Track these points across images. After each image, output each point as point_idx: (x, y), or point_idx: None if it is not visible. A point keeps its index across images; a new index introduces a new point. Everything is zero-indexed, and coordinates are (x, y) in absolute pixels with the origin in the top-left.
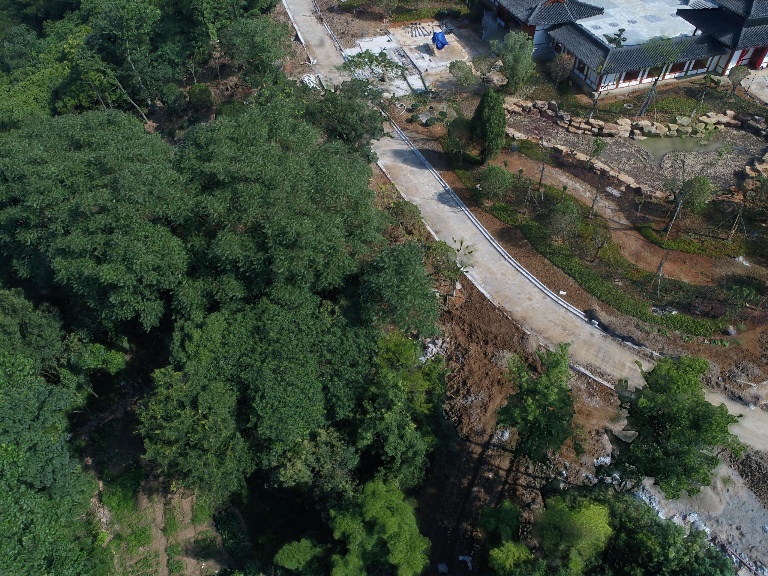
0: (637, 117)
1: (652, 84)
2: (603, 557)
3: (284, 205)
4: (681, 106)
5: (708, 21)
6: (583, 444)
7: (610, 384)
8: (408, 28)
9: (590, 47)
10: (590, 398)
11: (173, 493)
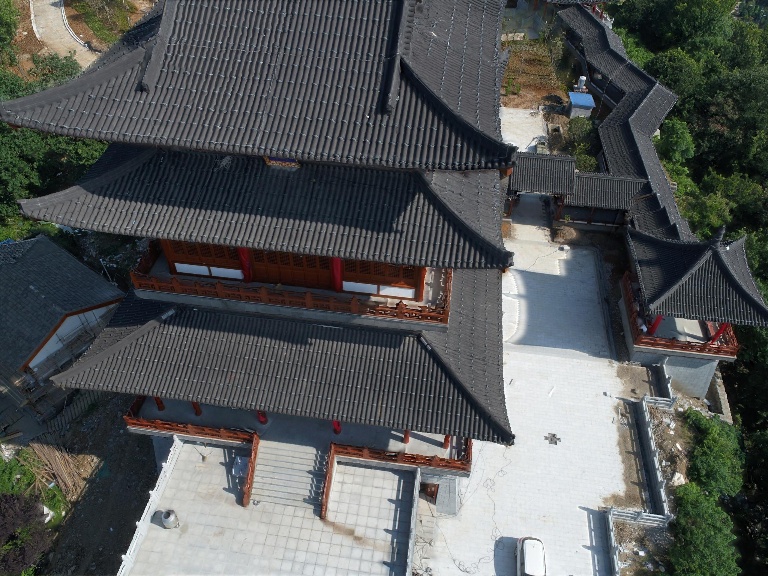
0: None
1: None
2: None
3: None
4: None
5: None
6: (4, 60)
7: None
8: None
9: None
10: None
11: None
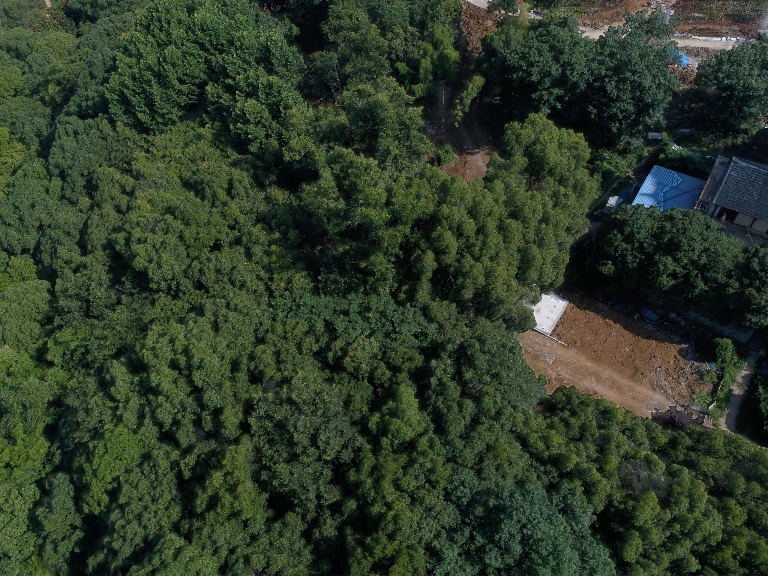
0: None
1: None
2: None
3: None
4: None
5: None
6: None
7: None
8: None
9: None
10: None
11: None
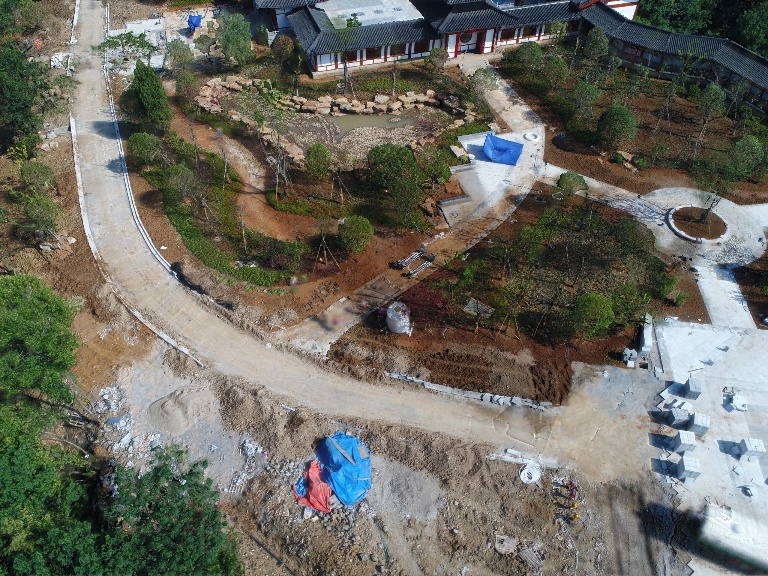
0: (340, 95)
1: (373, 66)
2: None
3: None
4: (388, 86)
5: (430, 7)
6: None
7: (153, 325)
8: (183, 12)
9: (310, 29)
10: (129, 337)
11: None
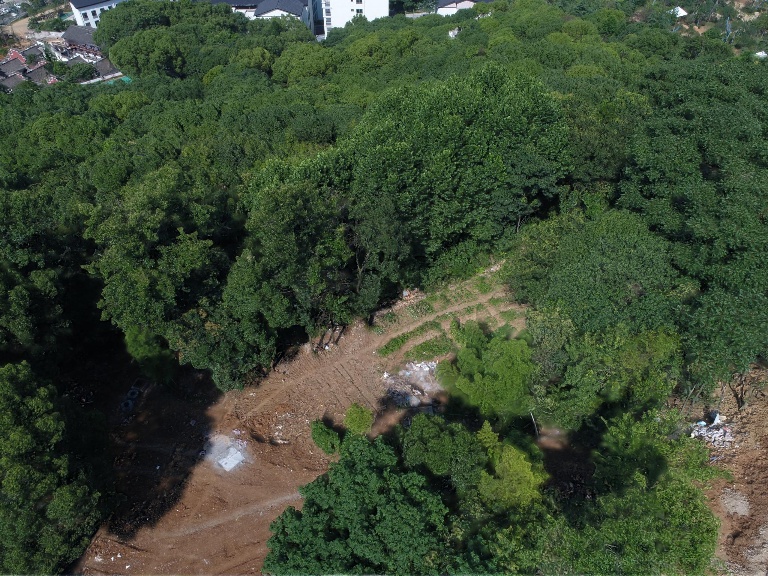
0: None
1: None
2: (500, 513)
3: (763, 202)
4: None
5: None
6: None
7: None
8: None
9: None
10: None
11: None
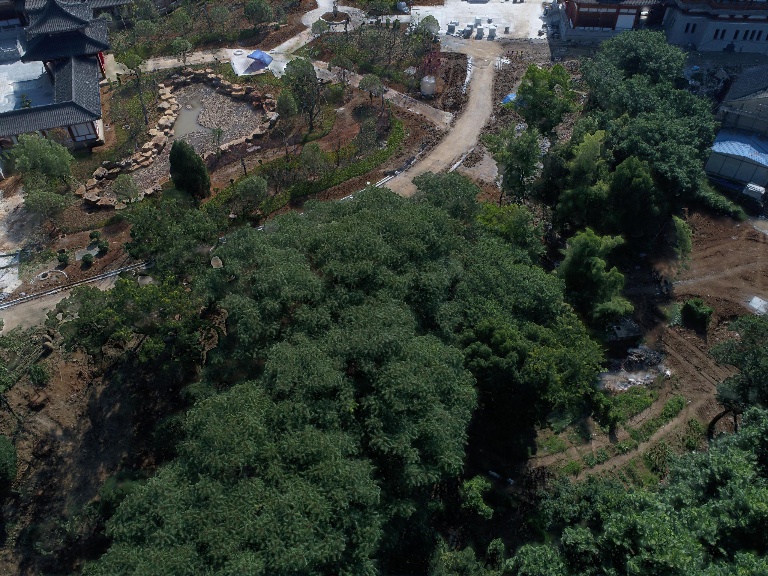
0: (149, 125)
1: None
2: None
3: None
4: None
5: (54, 50)
6: None
7: None
8: None
9: (50, 114)
10: None
11: (544, 475)
